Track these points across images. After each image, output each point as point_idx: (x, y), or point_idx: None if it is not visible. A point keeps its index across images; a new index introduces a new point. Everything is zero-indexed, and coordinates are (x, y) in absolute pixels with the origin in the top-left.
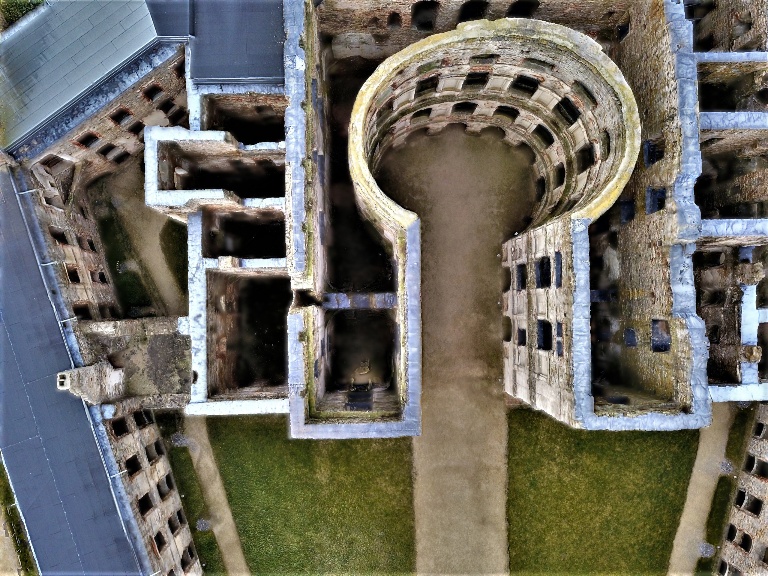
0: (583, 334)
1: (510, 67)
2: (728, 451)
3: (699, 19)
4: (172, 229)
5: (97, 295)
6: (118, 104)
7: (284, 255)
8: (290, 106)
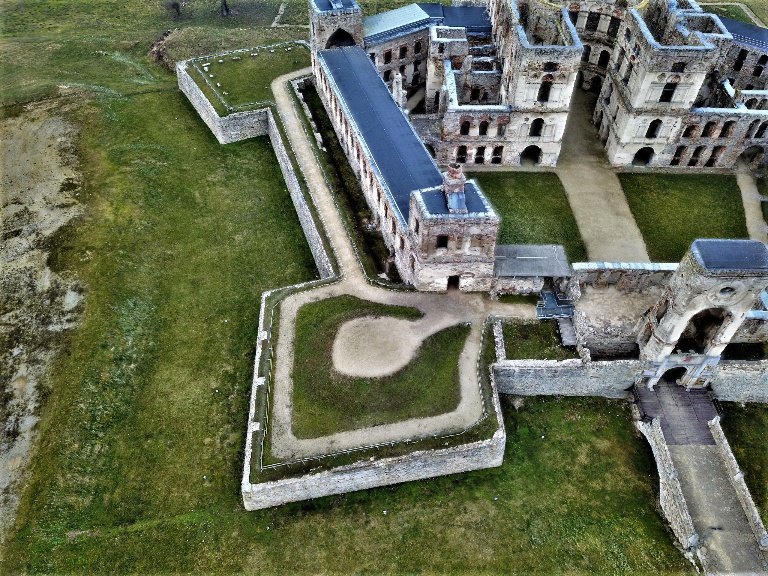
0: (646, 30)
1: (587, 5)
2: (760, 192)
3: None
4: None
5: None
6: (406, 42)
7: None
8: None
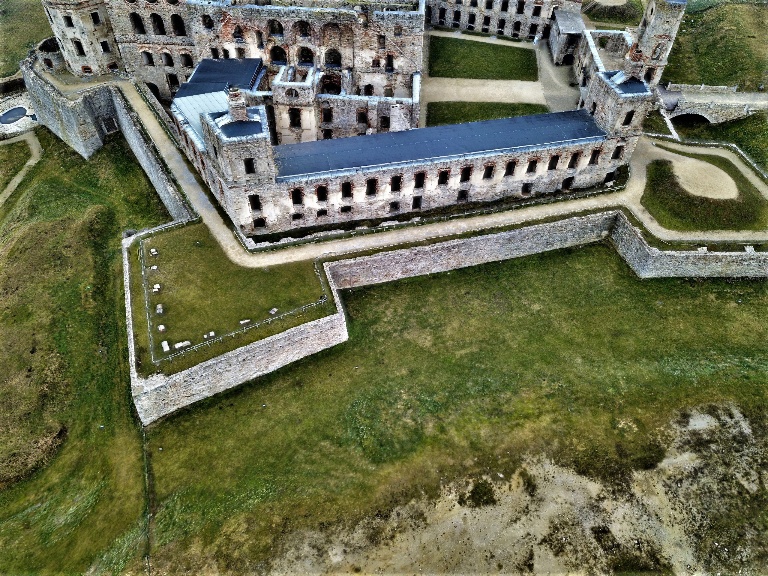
0: None
1: None
2: None
3: None
4: None
5: None
6: None
7: None
8: (287, 8)
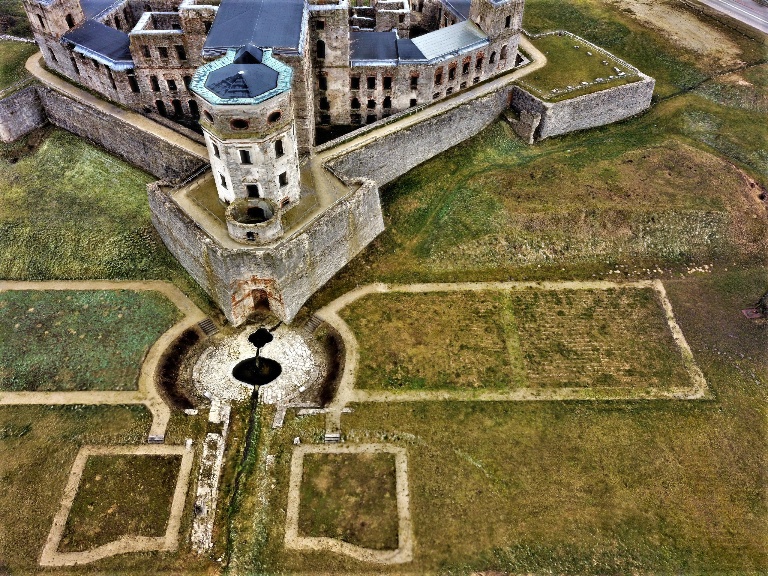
0: None
1: None
2: None
3: (156, 80)
4: None
5: None
6: None
7: None
8: None
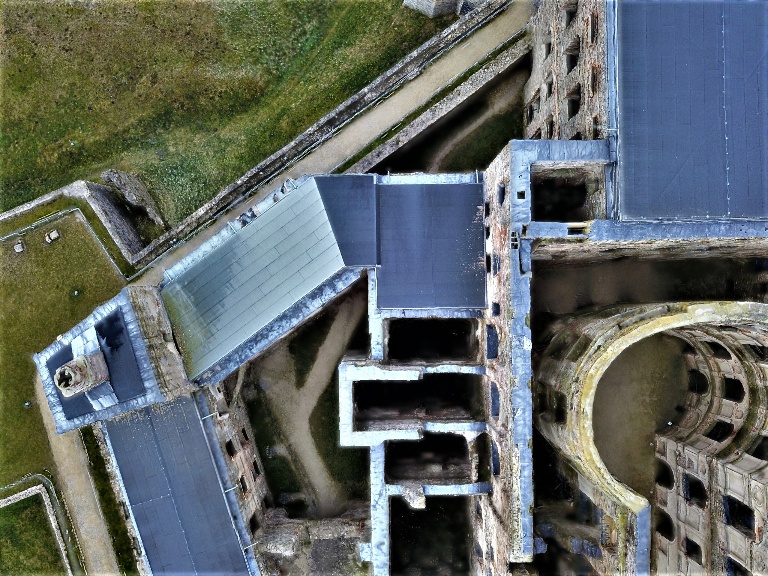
0: None
1: None
2: None
3: None
4: (321, 413)
5: (259, 495)
6: None
7: (448, 458)
8: (518, 387)
